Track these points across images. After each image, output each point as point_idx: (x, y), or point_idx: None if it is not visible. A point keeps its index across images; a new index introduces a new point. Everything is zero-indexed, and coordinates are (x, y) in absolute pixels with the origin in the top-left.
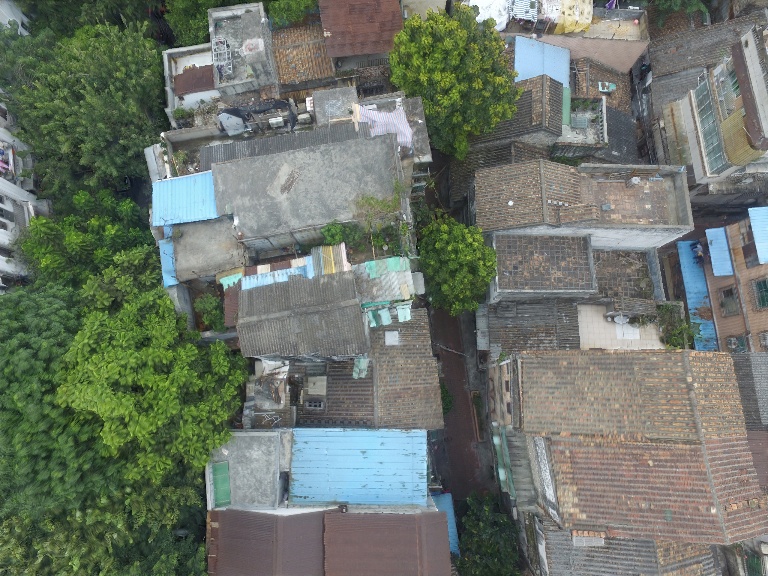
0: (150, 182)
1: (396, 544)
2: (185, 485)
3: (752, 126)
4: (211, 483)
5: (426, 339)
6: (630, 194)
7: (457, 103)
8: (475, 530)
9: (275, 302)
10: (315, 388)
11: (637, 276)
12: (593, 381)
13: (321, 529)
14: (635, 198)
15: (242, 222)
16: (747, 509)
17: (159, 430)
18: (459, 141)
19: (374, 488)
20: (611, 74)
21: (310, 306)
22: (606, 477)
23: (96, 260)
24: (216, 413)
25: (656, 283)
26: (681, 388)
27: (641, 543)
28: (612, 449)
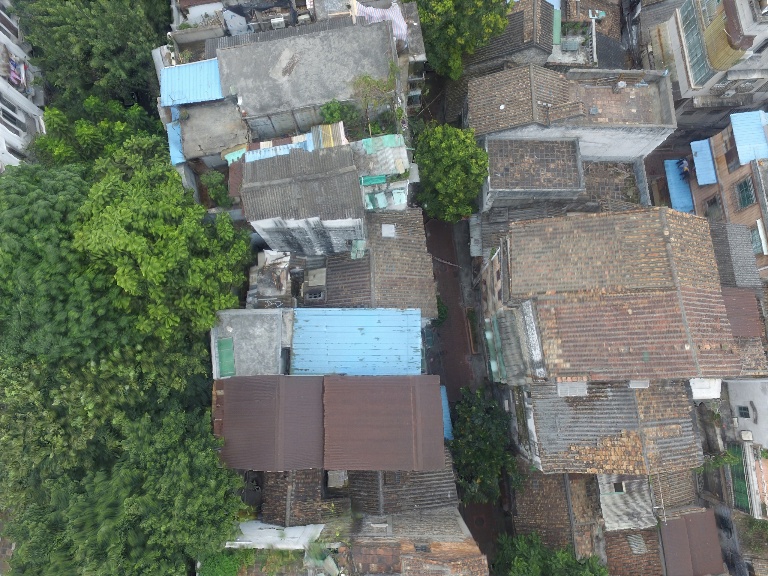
0: (157, 91)
1: (391, 402)
2: (192, 356)
3: (732, 26)
4: (216, 356)
5: (421, 236)
6: (617, 99)
7: (451, 13)
8: (468, 416)
9: (277, 171)
10: (315, 280)
11: (624, 185)
12: (577, 243)
13: (321, 392)
14: (621, 103)
15: (246, 102)
16: (720, 352)
17: (169, 280)
18: (453, 60)
19: (371, 361)
20: (601, 3)
21: (310, 174)
22: (588, 328)
23: (106, 155)
24: (222, 272)
25: (642, 190)
26: (659, 242)
27: (623, 401)
28: (594, 303)
